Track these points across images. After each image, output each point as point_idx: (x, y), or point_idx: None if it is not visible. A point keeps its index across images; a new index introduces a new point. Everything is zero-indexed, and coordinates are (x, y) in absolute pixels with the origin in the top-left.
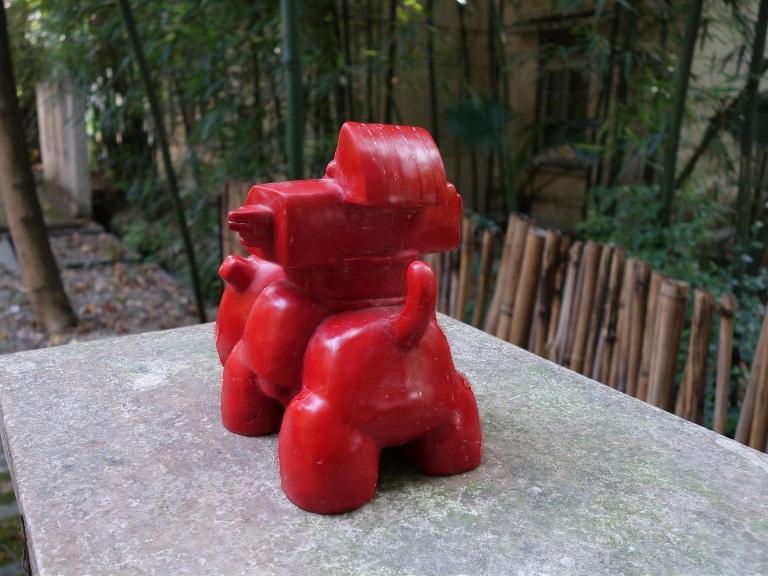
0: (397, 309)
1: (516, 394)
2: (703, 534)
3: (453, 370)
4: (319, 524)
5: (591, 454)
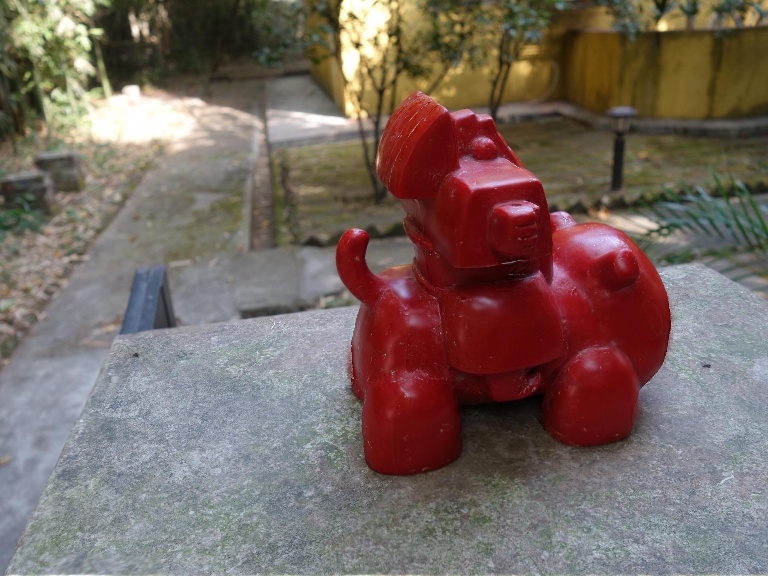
0: (408, 283)
1: (545, 575)
2: (156, 572)
3: (378, 361)
4: (349, 377)
5: (339, 569)
